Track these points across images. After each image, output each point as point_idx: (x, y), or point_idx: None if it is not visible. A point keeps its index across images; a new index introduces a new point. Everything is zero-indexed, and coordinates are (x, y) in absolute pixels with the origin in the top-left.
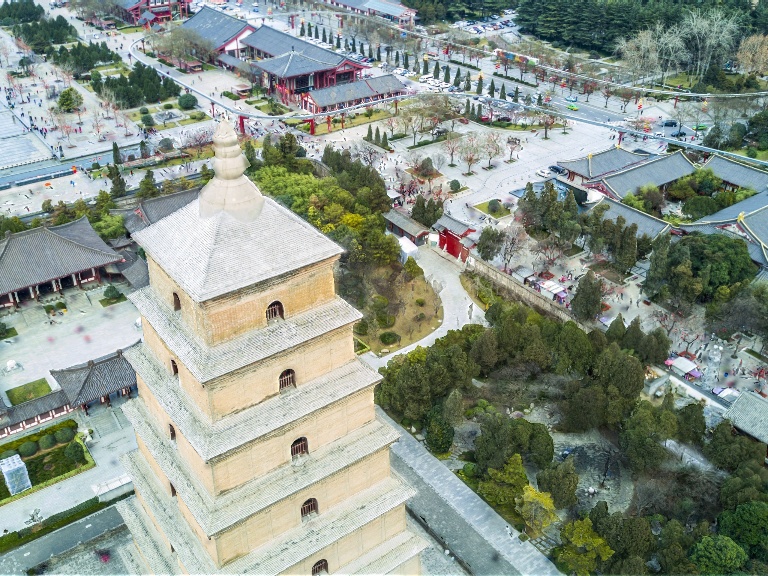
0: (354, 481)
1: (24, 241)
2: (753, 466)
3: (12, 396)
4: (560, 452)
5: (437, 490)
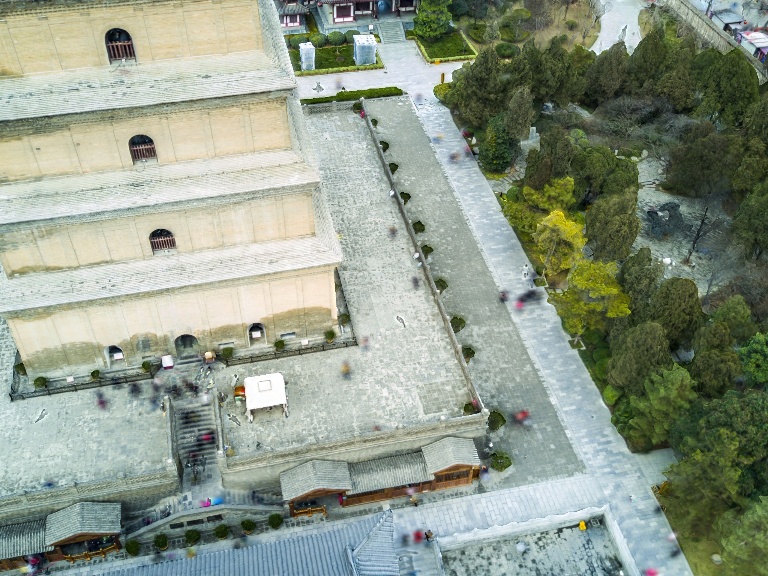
0: (196, 31)
1: None
2: None
3: None
4: None
5: (463, 206)
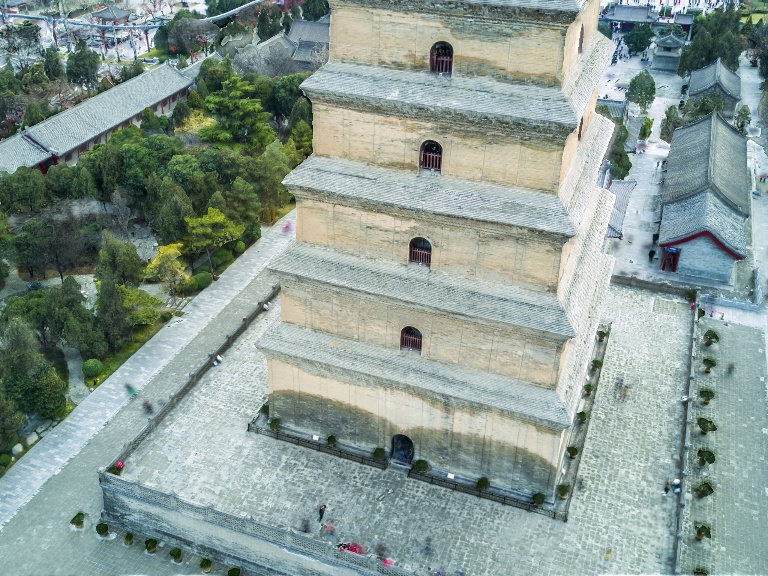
0: None
1: None
2: (58, 168)
3: None
4: None
5: (139, 389)
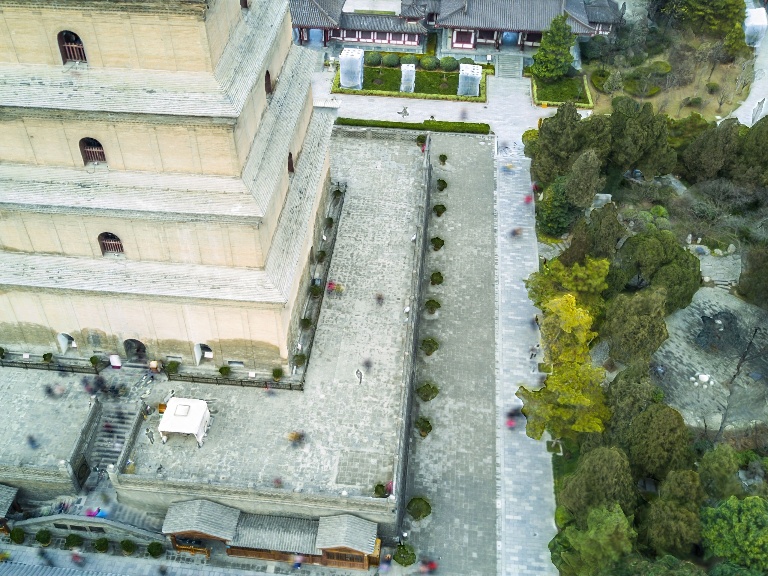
0: (145, 45)
1: None
2: None
3: None
4: (711, 316)
5: (499, 265)
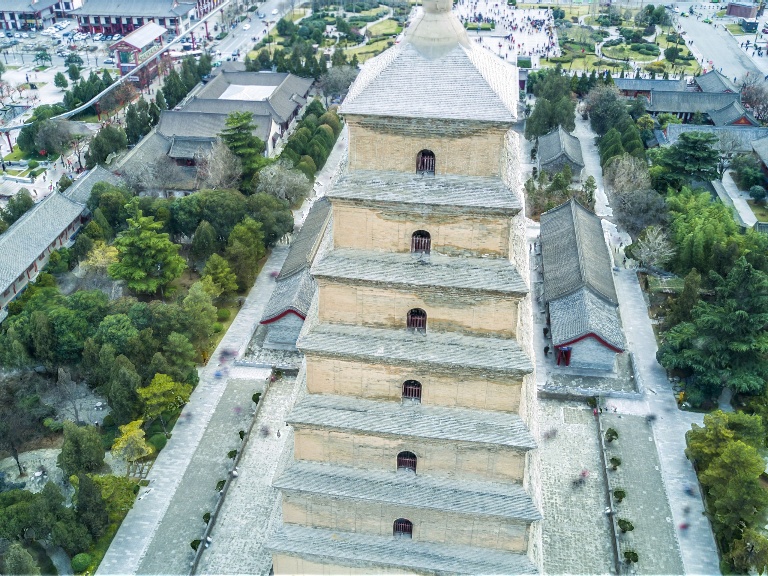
0: None
1: None
2: None
3: None
4: None
5: (132, 575)
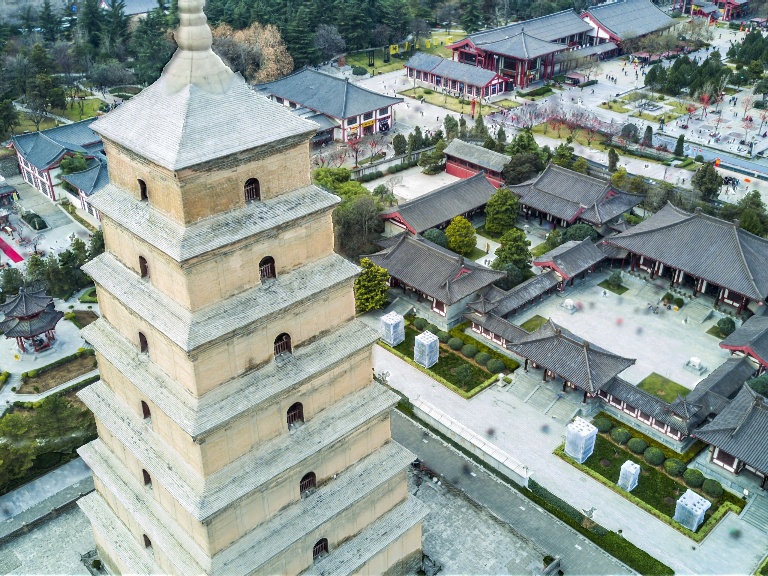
0: None
1: (707, 226)
2: None
3: (533, 320)
4: None
5: None
